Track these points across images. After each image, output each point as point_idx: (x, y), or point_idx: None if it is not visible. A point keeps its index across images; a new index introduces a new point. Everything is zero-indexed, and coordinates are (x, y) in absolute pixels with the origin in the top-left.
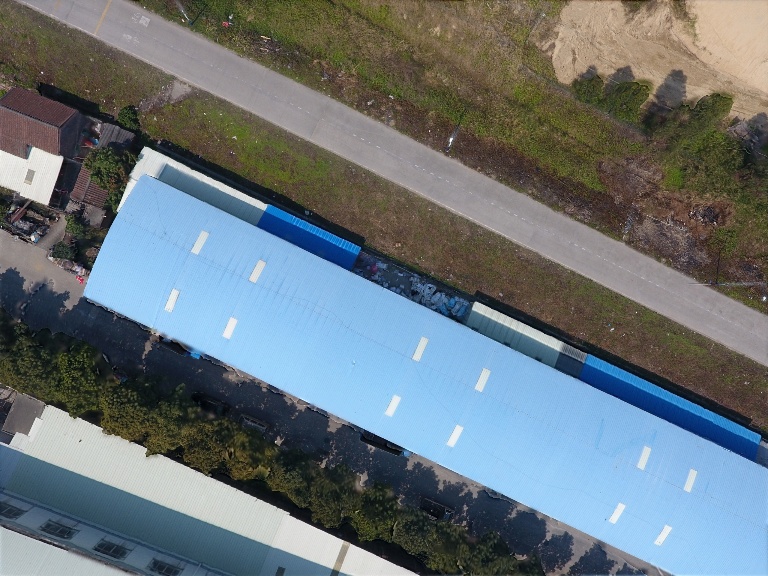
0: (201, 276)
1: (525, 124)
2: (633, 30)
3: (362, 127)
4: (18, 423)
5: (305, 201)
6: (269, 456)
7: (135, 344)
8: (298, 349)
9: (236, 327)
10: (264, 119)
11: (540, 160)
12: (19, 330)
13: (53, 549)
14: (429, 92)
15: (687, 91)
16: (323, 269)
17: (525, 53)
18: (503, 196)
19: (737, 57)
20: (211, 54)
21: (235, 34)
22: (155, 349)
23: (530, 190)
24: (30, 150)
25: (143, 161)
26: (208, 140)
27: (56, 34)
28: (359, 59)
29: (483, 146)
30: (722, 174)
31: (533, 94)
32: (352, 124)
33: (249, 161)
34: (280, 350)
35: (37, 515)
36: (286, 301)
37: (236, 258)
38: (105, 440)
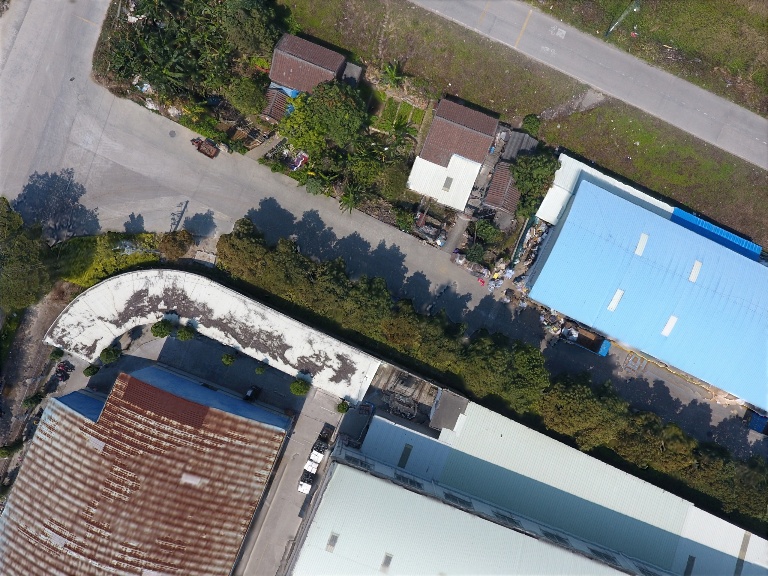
0: (645, 276)
1: None
2: None
3: (764, 131)
4: (444, 419)
5: (695, 203)
6: (694, 449)
7: (531, 343)
8: (734, 345)
9: (676, 325)
10: (672, 125)
11: None
12: (463, 330)
13: (525, 538)
14: None
15: None
16: (751, 268)
17: None
18: None
19: None
20: (623, 63)
21: (644, 44)
22: (550, 347)
23: None
24: (450, 158)
25: (561, 167)
26: (607, 146)
27: (479, 47)
28: (757, 65)
29: None
30: None
31: None
32: (755, 128)
33: (645, 165)
34: (717, 347)
35: (482, 506)
36: (723, 299)
37: (675, 259)
38: (523, 435)
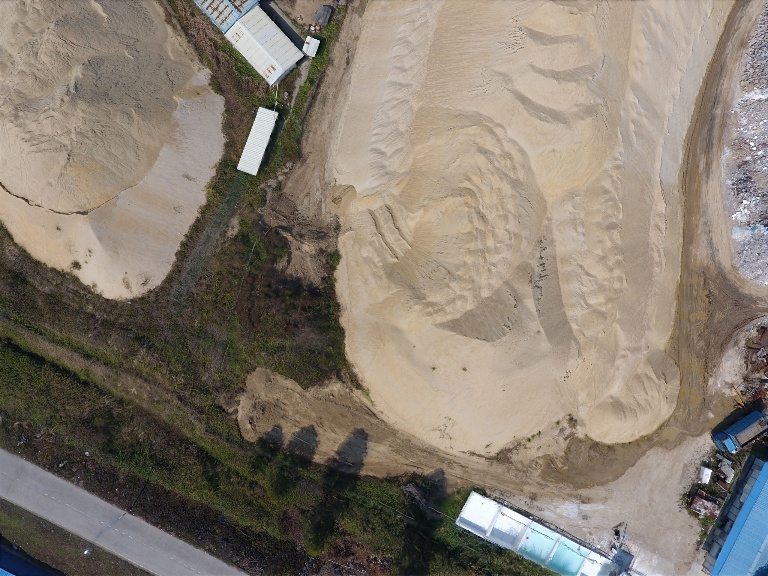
0: None
1: (201, 490)
2: (314, 395)
3: (53, 487)
4: None
5: (12, 539)
6: None
7: None
8: None
9: None
10: None
11: (223, 513)
12: None
13: None
14: (116, 455)
15: (368, 447)
16: None
17: (209, 418)
18: (181, 551)
19: (410, 423)
20: None
21: None
22: None
23: (207, 546)
24: None
25: None
26: None
27: None
28: (56, 422)
29: (171, 498)
30: (386, 537)
31: (220, 451)
32: (44, 484)
33: None
34: None
35: None
36: None
37: None
38: None
